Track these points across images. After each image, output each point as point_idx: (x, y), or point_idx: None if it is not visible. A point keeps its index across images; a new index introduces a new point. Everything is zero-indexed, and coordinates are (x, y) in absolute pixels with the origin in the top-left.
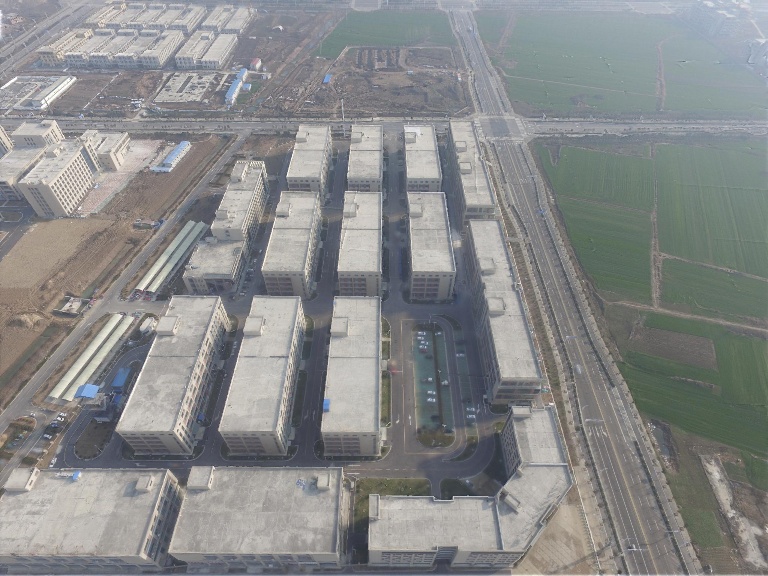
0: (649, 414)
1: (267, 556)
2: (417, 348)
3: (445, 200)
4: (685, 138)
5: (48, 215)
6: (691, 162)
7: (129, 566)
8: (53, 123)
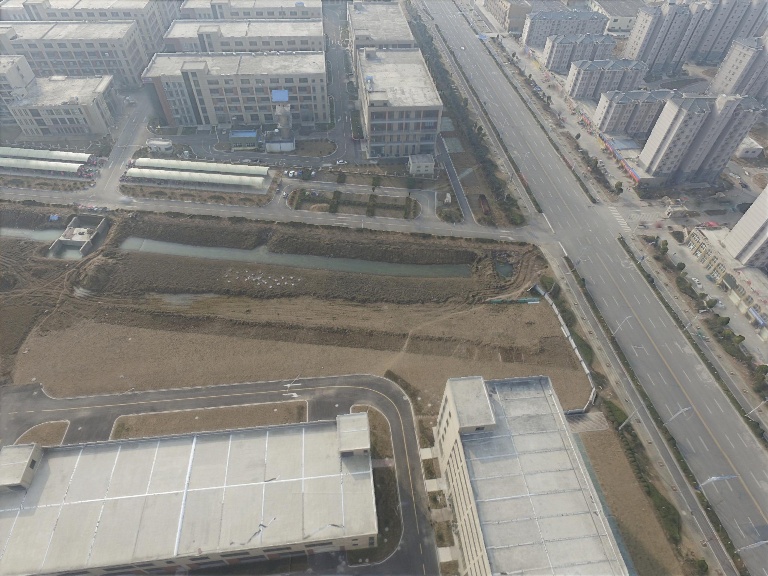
0: None
1: None
2: None
3: None
4: None
5: None
6: None
7: None
8: None
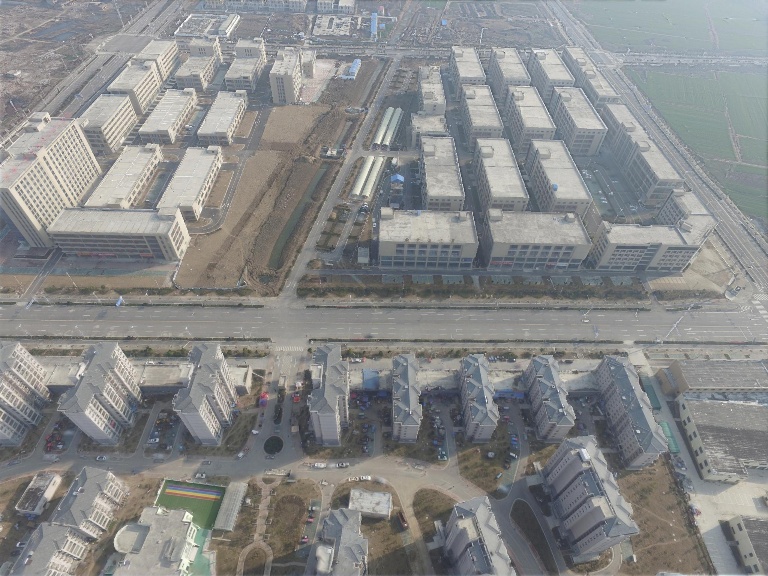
0: (748, 212)
1: (545, 253)
2: (584, 178)
3: (583, 92)
4: (740, 68)
5: (281, 102)
6: (747, 83)
7: (453, 266)
8: (262, 40)
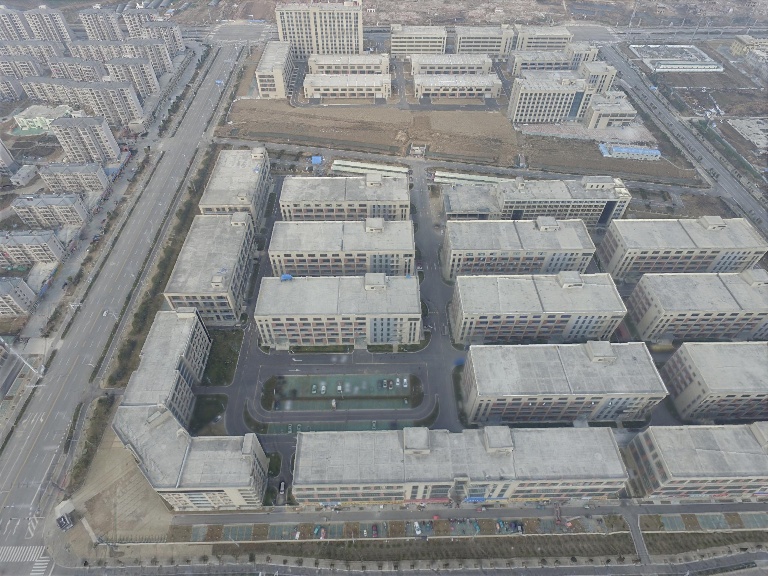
0: None
1: None
2: (384, 378)
3: (646, 392)
4: None
5: None
6: None
7: None
8: (613, 71)
